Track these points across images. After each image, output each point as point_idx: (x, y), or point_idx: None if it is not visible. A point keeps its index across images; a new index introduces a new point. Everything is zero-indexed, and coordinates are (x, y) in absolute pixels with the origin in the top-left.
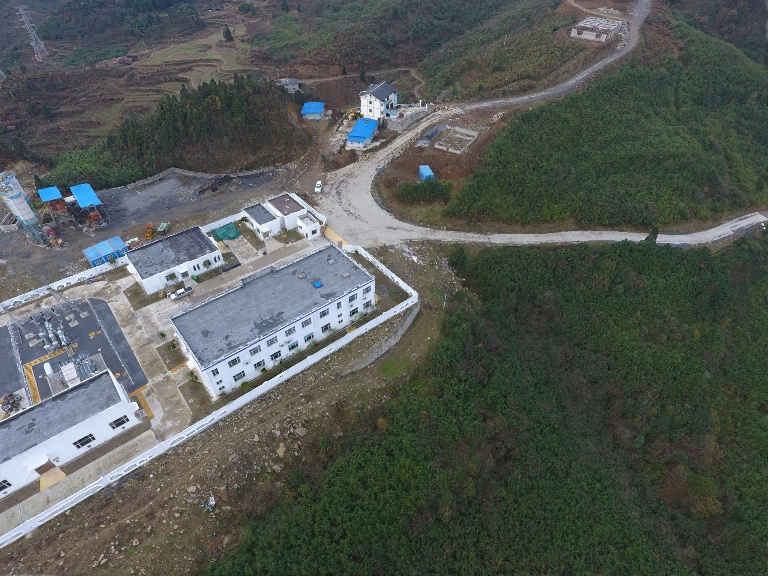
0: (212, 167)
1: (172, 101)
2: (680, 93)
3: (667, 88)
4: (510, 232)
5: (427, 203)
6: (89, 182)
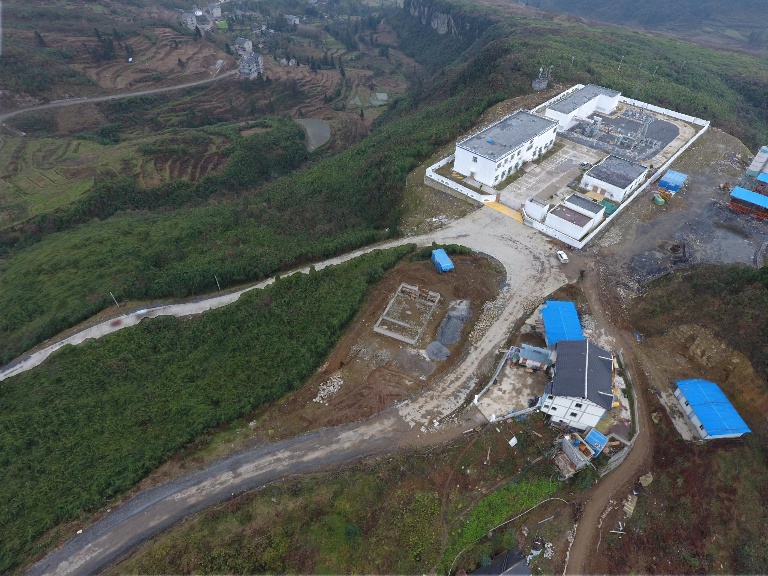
0: None
1: None
2: None
3: None
4: None
5: None
6: None
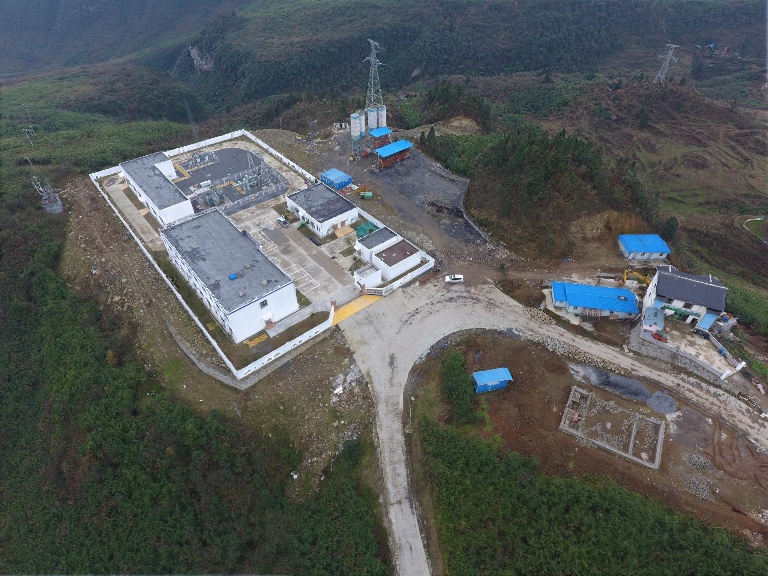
0: None
1: (545, 137)
2: None
3: None
4: (433, 553)
5: None
6: None
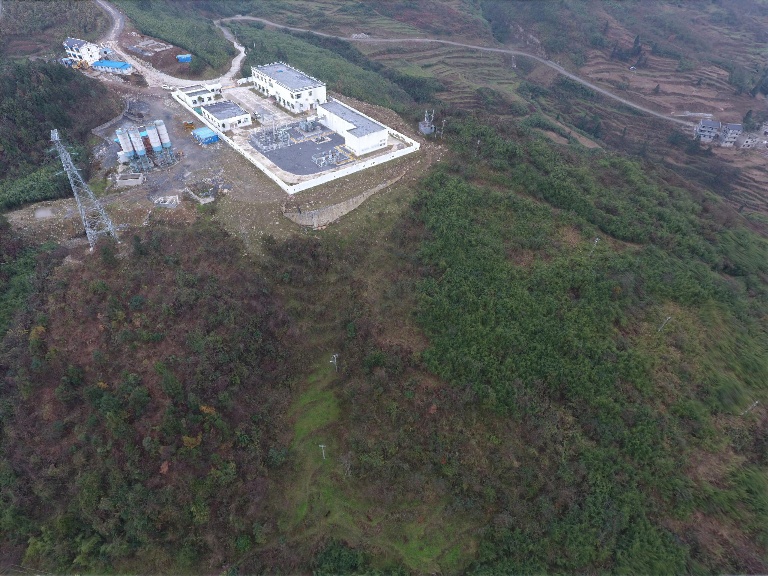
0: (110, 114)
1: (7, 98)
2: (135, 8)
3: (129, 7)
4: (228, 69)
5: (204, 69)
6: (81, 163)
